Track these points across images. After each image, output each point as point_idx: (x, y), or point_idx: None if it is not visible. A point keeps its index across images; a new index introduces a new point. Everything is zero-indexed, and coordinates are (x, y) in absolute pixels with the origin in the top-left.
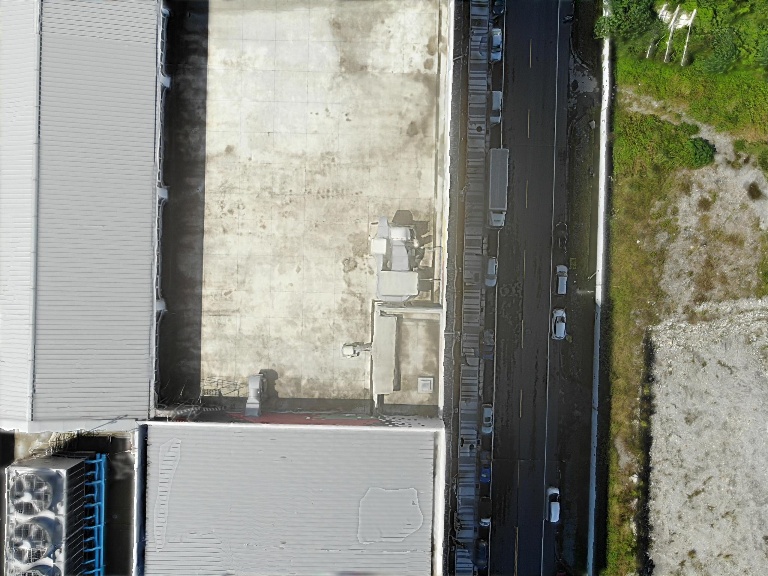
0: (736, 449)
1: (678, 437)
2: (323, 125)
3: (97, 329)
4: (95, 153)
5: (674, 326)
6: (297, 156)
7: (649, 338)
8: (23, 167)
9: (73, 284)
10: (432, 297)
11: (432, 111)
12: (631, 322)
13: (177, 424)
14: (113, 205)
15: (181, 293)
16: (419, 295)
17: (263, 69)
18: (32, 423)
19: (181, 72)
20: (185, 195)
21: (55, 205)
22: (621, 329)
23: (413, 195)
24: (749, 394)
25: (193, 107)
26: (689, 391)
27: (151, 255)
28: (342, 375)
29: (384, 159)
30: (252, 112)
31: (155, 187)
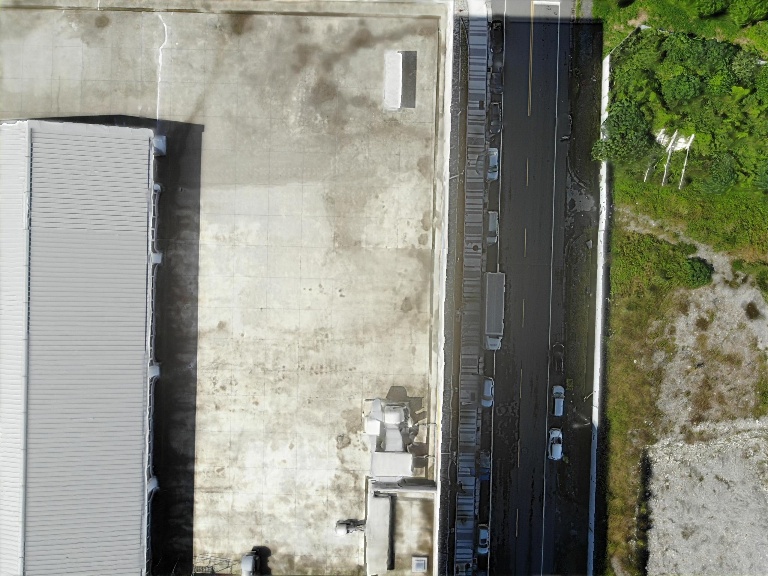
0: (733, 563)
1: (675, 552)
2: (316, 301)
3: (88, 522)
4: (85, 345)
5: (671, 445)
6: (290, 332)
7: (646, 455)
8: (12, 363)
9: (63, 478)
10: (426, 474)
11: (426, 287)
12: (628, 442)
13: None
14: (104, 396)
15: (173, 470)
16: (413, 472)
17: (256, 244)
18: None
19: (173, 247)
20: (177, 371)
21: (45, 400)
22: (618, 449)
23: (407, 371)
24: (746, 509)
25: (185, 283)
26: (686, 505)
27: (142, 444)
28: (335, 552)
29: (378, 335)
30: (245, 288)
31: (146, 375)
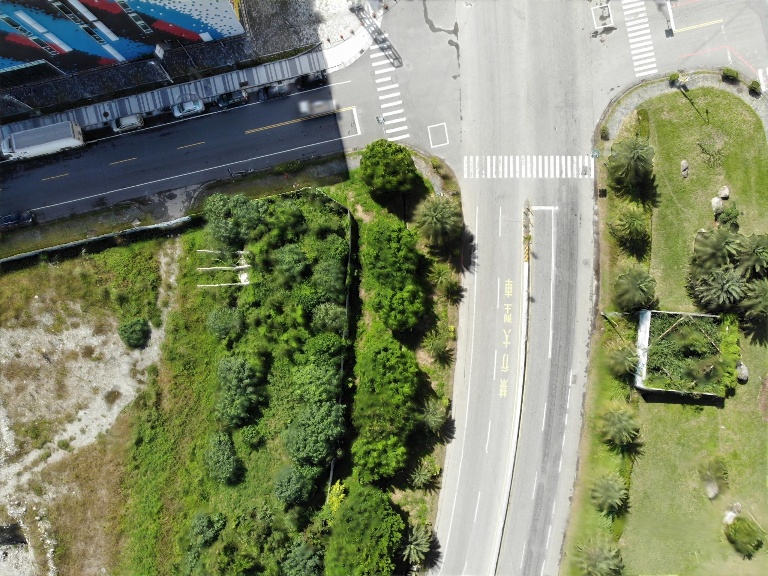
0: None
1: None
2: None
3: None
4: None
5: None
6: None
7: None
8: None
9: None
10: None
11: None
12: None
13: None
14: None
15: None
16: None
17: None
18: None
19: None
20: None
21: None
22: None
23: None
24: None
25: None
26: None
27: None
28: None
29: None
30: None
31: None
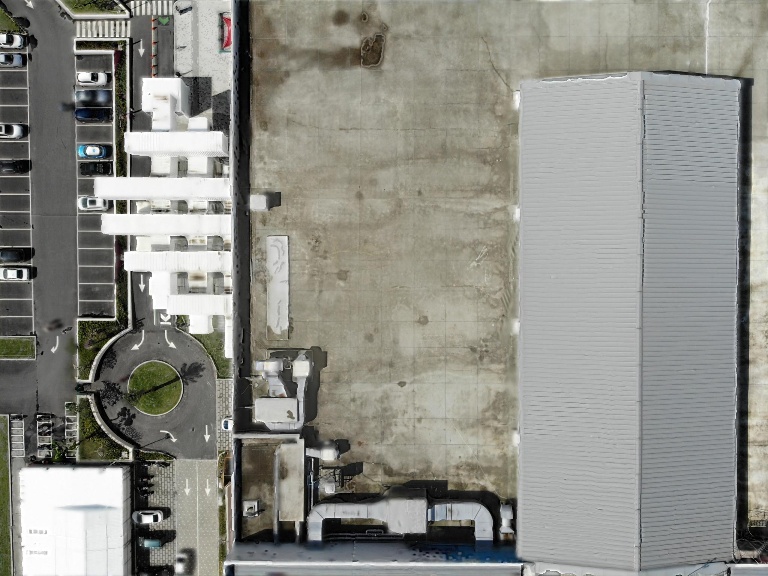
0: None
1: None
2: None
3: (691, 474)
4: (688, 297)
5: None
6: None
7: None
8: (625, 315)
9: (671, 430)
10: None
11: None
12: None
13: (767, 566)
14: (703, 348)
15: None
16: None
17: None
18: (640, 573)
19: None
20: None
21: (656, 352)
22: None
23: None
24: None
25: None
26: None
27: (734, 396)
28: None
29: None
30: None
31: None
